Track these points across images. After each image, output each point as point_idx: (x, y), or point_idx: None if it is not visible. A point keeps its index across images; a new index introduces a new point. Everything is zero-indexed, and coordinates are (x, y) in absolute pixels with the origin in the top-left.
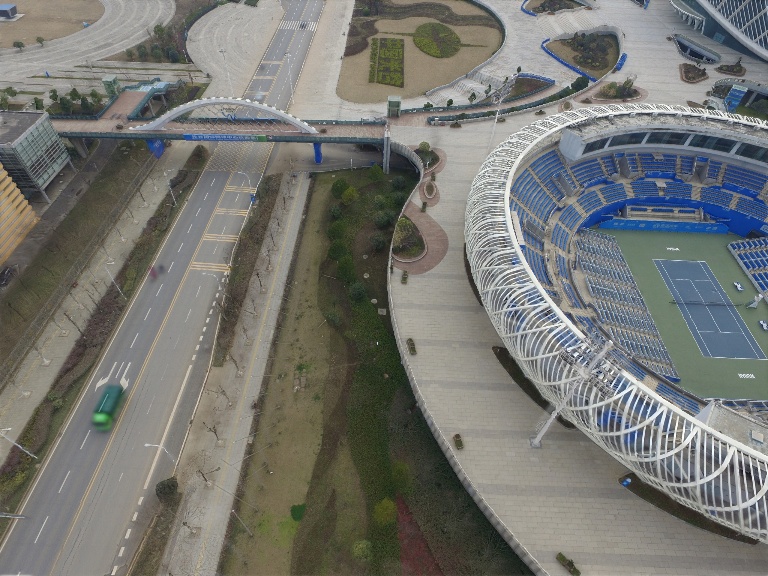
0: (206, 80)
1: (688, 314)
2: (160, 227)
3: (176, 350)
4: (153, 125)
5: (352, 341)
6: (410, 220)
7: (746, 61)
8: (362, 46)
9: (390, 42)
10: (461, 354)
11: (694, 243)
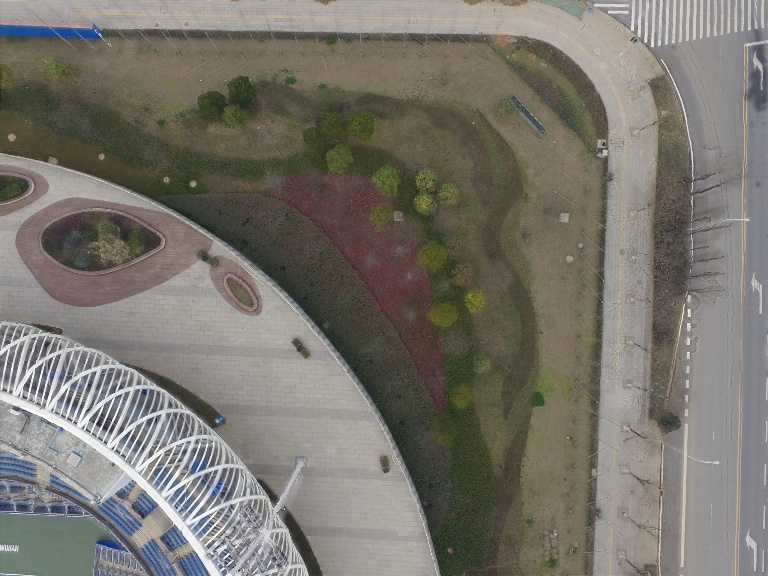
0: None
1: None
2: None
3: None
4: None
5: None
6: None
7: None
8: None
9: None
10: None
11: None
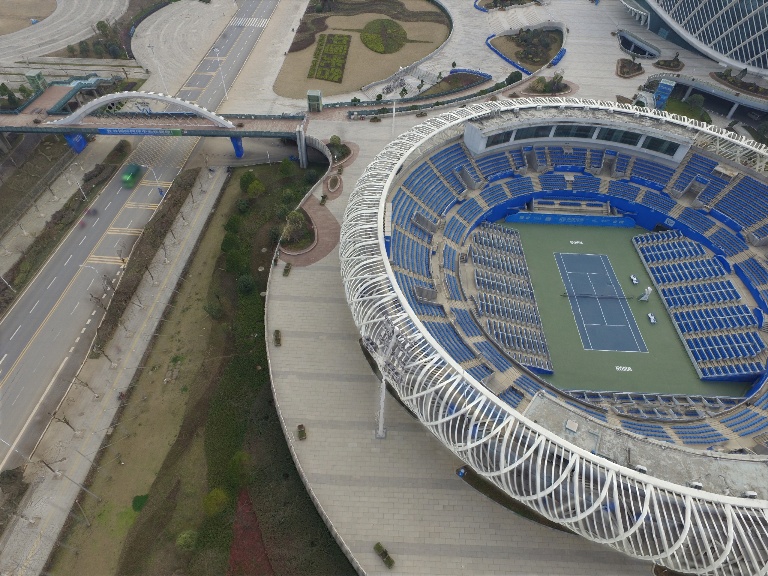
0: (144, 76)
1: (577, 307)
2: (64, 221)
3: (55, 342)
4: (70, 119)
5: (232, 333)
6: (306, 213)
7: (686, 56)
8: (308, 42)
9: (337, 38)
10: (326, 346)
11: (599, 237)
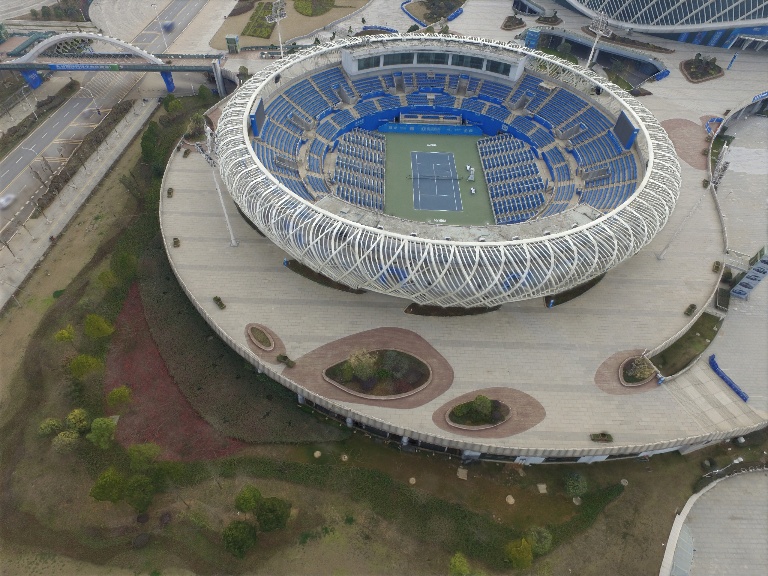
0: None
1: (418, 185)
2: (18, 133)
3: (5, 209)
4: (25, 58)
5: (143, 201)
6: (209, 119)
7: (567, 15)
8: (247, 8)
9: None
10: (207, 197)
11: (452, 142)
